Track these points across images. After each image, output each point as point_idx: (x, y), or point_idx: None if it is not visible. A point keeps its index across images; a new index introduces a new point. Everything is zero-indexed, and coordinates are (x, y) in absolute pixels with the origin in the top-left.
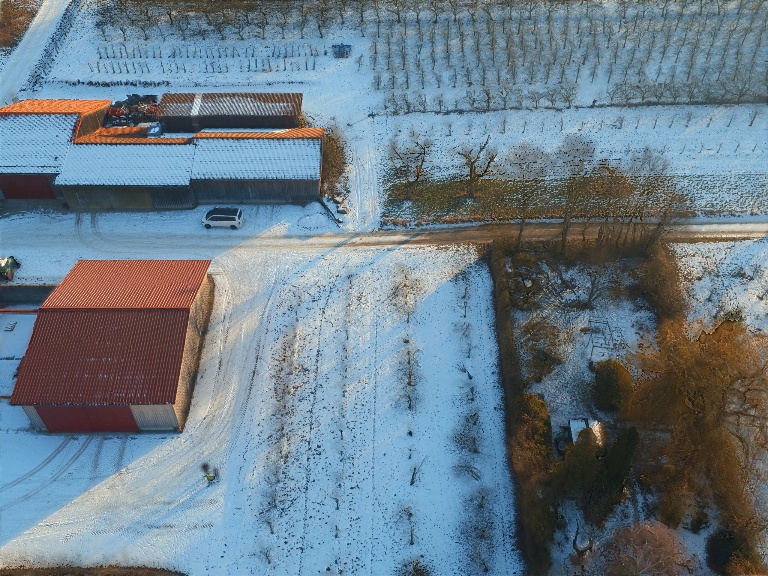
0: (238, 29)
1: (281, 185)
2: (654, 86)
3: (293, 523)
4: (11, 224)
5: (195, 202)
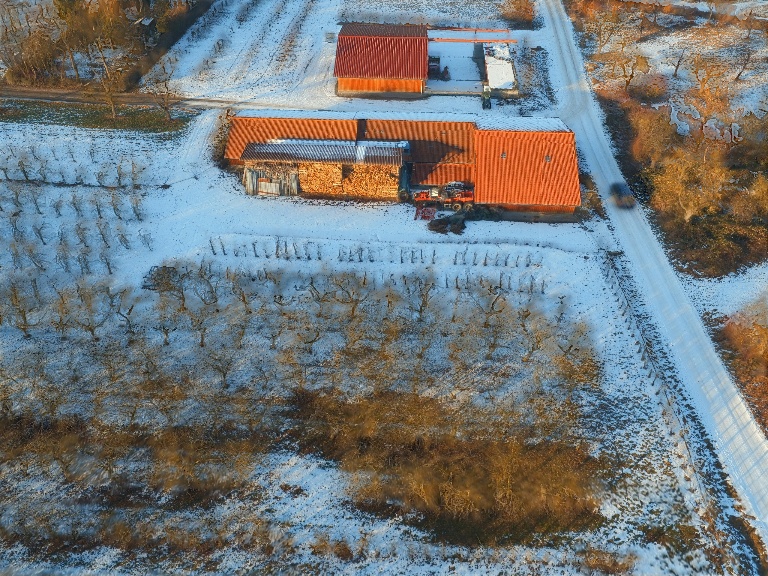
0: None
1: None
2: None
3: None
4: None
5: None
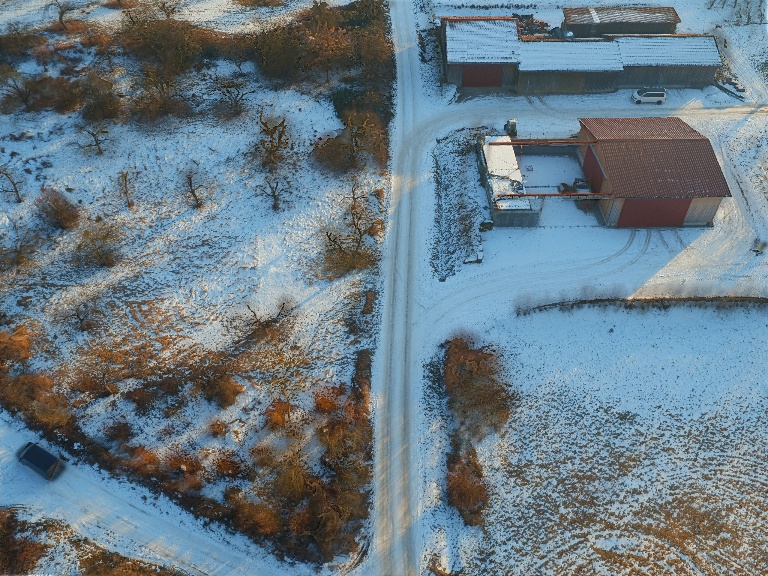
0: None
1: (687, 72)
2: None
3: None
4: (479, 104)
5: (615, 87)
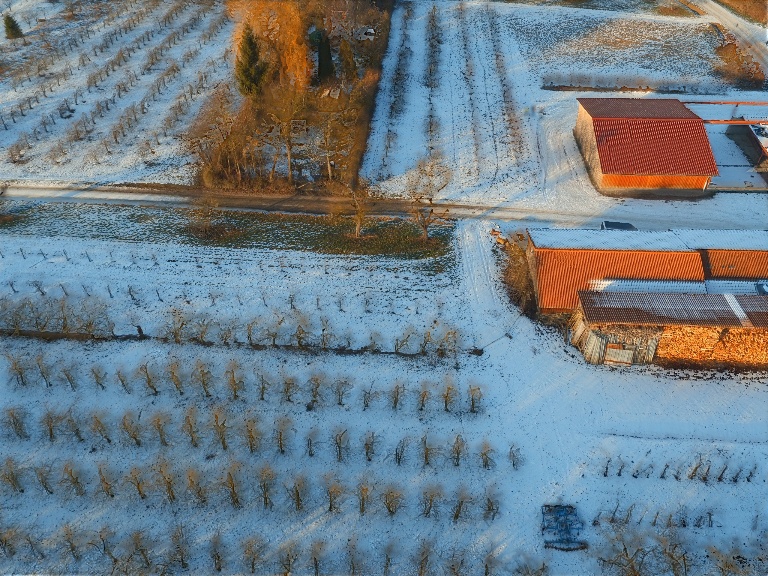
0: None
1: None
2: (47, 313)
3: None
4: None
5: None
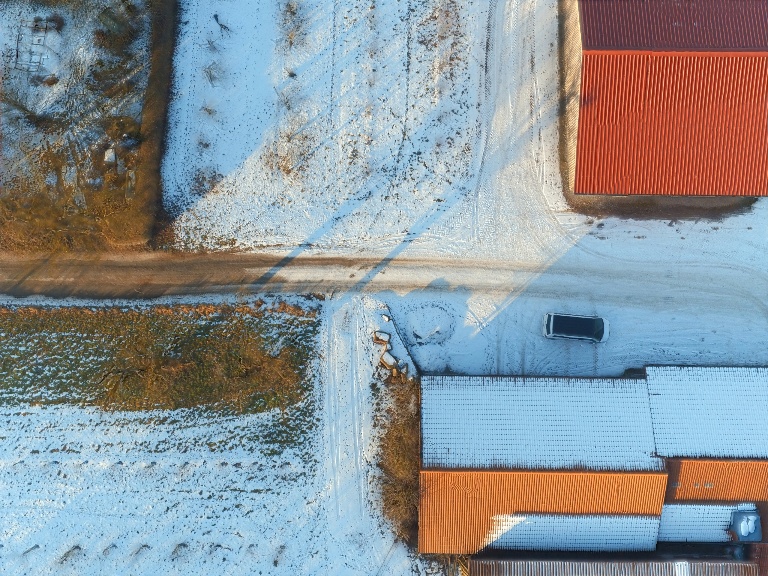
0: None
1: None
2: None
3: None
4: None
5: None
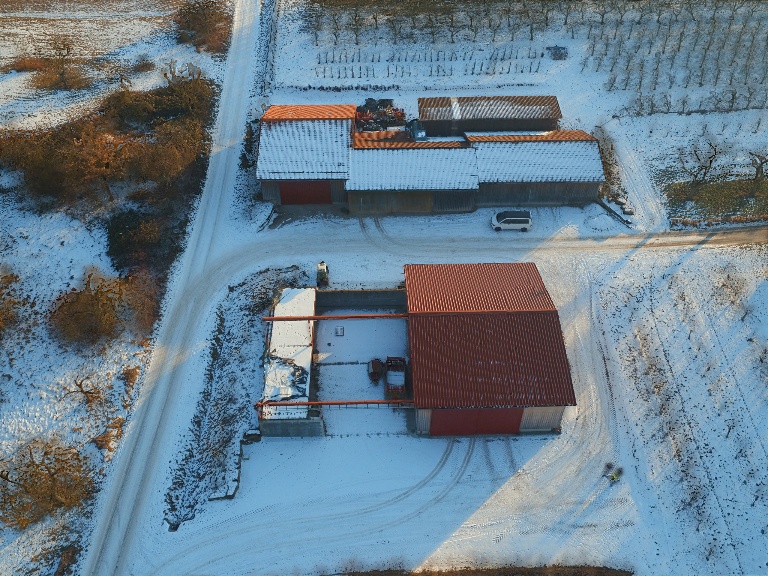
0: (451, 32)
1: (563, 187)
2: None
3: (714, 520)
4: (298, 230)
5: (474, 205)
